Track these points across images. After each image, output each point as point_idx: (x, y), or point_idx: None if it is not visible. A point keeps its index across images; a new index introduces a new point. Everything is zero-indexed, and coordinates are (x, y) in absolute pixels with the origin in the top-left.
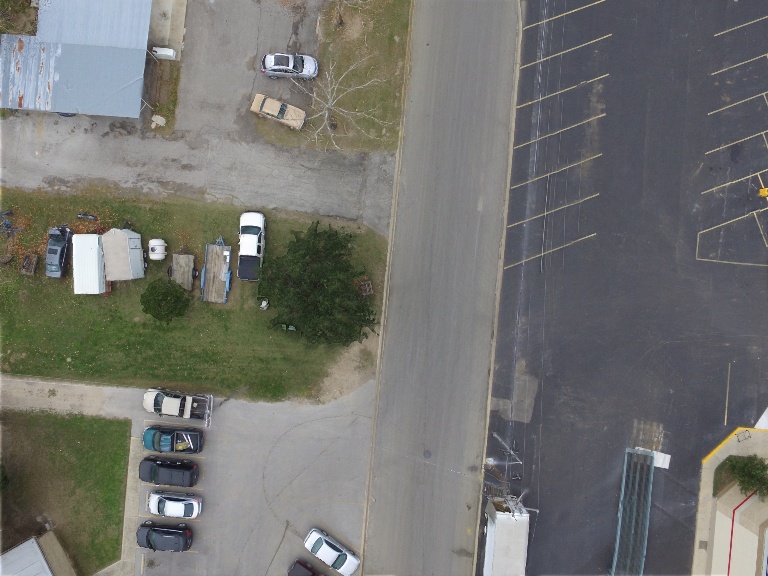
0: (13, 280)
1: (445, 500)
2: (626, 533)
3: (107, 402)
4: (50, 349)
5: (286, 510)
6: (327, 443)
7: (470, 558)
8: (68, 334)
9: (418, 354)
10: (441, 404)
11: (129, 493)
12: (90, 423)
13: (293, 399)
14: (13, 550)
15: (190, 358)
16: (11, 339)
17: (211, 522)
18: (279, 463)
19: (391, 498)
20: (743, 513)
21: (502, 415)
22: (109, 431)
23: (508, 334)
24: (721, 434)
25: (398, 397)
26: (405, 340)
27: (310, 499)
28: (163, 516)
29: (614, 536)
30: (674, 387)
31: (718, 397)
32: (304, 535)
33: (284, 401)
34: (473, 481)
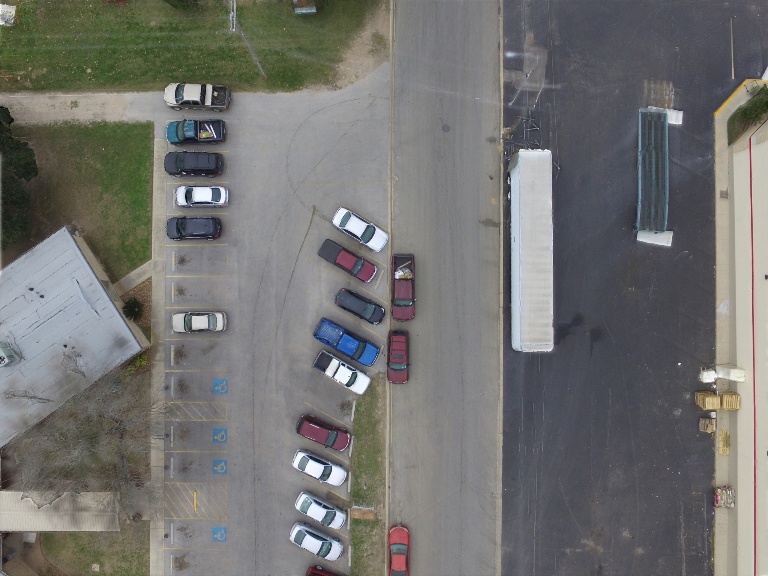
0: (30, 0)
1: (467, 171)
2: (647, 179)
3: (129, 108)
4: (70, 62)
5: (312, 195)
6: (347, 127)
7: (496, 228)
8: (87, 45)
9: (429, 33)
10: (455, 78)
11: (156, 193)
12: (113, 129)
13: (311, 87)
14: (45, 240)
15: (207, 57)
16: (31, 56)
17: (239, 214)
18: (301, 150)
19: (414, 174)
20: (759, 132)
21: (515, 85)
22: (132, 135)
23: (514, 8)
24: (730, 87)
25: (413, 76)
26: (415, 21)
27: (334, 182)
28: (191, 205)
29: (636, 187)
30: (680, 45)
31: (723, 48)
32: (331, 218)
33: (302, 89)
34: (493, 152)
